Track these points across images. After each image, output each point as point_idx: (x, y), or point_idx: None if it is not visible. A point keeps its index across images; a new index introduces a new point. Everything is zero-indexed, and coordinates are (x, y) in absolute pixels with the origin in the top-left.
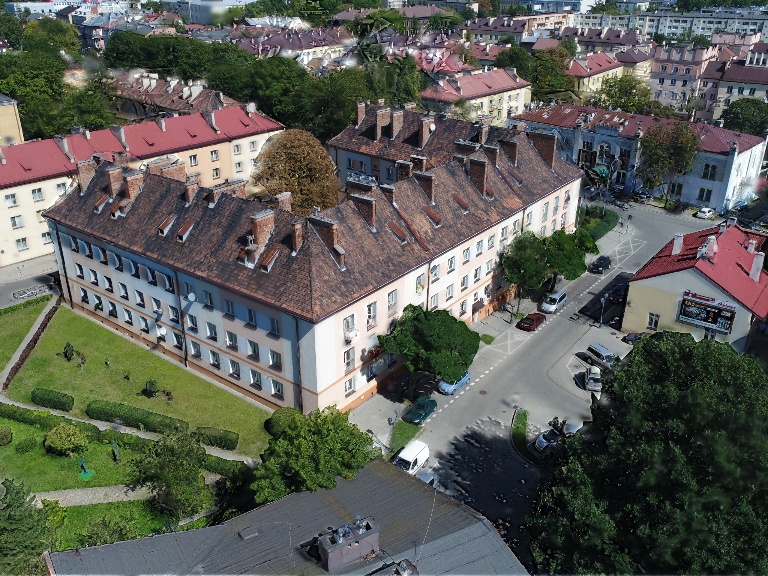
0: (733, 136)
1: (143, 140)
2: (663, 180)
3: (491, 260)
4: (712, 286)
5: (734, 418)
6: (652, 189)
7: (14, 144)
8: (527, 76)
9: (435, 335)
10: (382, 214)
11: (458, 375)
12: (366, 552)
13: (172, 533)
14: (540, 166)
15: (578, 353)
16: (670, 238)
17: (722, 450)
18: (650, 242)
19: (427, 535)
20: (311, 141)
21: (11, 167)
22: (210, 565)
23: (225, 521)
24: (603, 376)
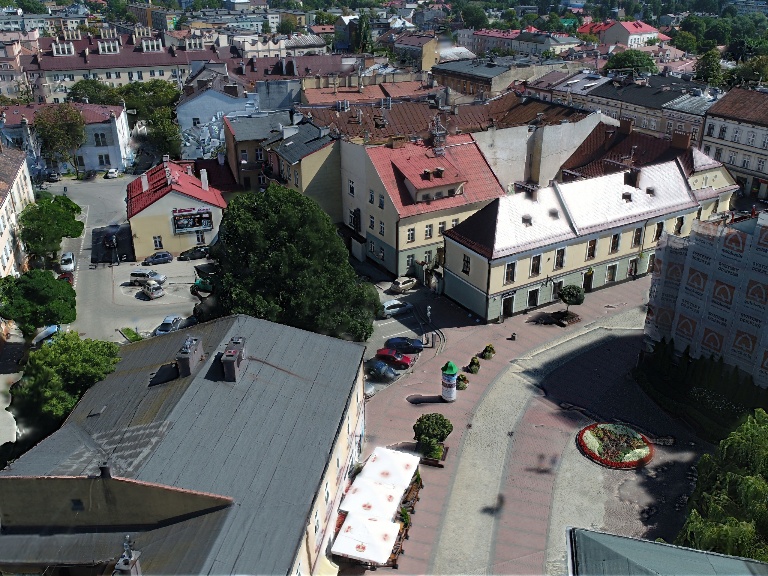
0: (102, 108)
1: None
2: (69, 154)
3: (8, 239)
4: (190, 199)
5: (308, 217)
6: (57, 167)
7: None
8: None
9: (46, 288)
10: None
11: (74, 316)
12: (200, 357)
13: (45, 439)
14: None
15: (122, 284)
16: (104, 197)
17: (312, 234)
18: (92, 204)
19: (218, 337)
20: None
21: None
22: (102, 430)
23: (62, 426)
24: (221, 235)
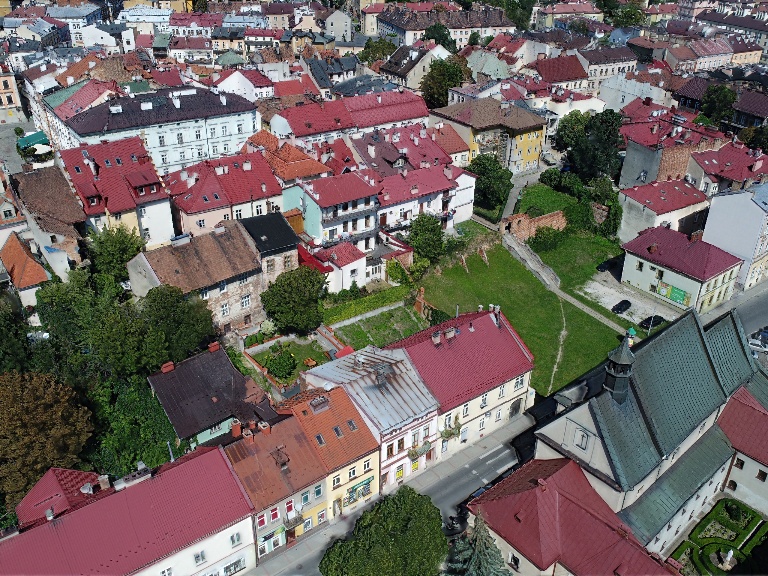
0: None
1: (412, 7)
2: None
3: (467, 38)
4: None
5: None
6: None
7: (378, 3)
8: (601, 8)
9: None
10: (434, 17)
11: None
12: None
13: None
14: (498, 20)
15: None
16: None
17: None
18: None
19: None
20: (443, 7)
21: (375, 9)
22: None
23: None
24: None
